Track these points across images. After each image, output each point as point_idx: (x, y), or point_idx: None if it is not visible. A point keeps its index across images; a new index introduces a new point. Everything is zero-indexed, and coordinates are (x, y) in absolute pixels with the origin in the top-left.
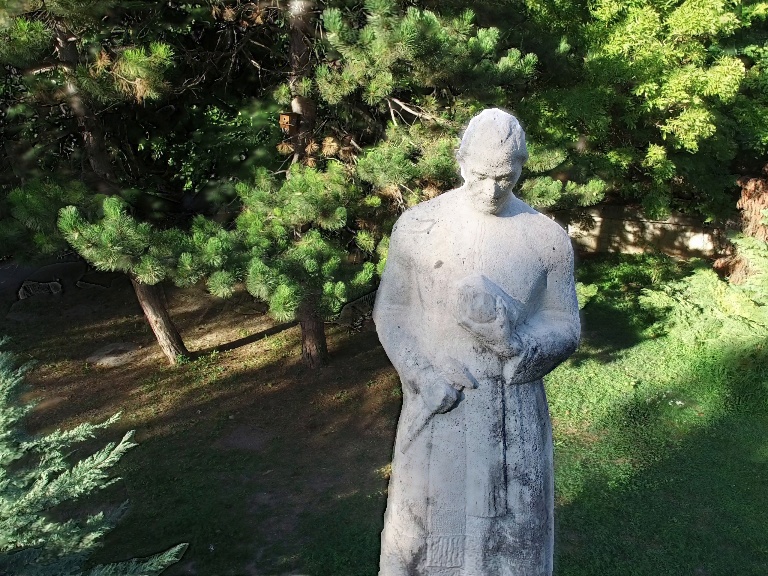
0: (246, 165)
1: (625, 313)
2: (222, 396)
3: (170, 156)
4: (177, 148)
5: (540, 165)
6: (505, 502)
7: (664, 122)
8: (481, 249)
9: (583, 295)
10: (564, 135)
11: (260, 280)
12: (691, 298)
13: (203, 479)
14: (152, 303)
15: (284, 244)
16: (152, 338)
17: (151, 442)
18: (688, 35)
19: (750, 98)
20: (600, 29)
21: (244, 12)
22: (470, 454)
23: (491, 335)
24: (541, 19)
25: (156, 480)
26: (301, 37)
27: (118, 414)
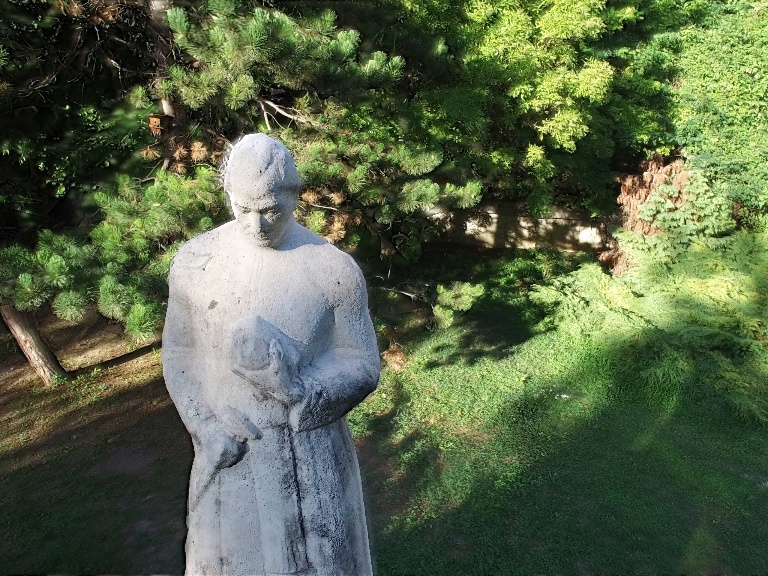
0: (110, 172)
1: (518, 308)
2: (101, 418)
3: (41, 160)
4: (48, 152)
5: (417, 168)
6: (304, 555)
7: (540, 123)
8: (256, 286)
9: (470, 295)
10: (446, 136)
11: (111, 300)
12: (578, 291)
13: (74, 512)
14: (19, 322)
15: (146, 258)
16: (22, 359)
17: (17, 475)
18: (559, 38)
19: (626, 98)
20: (477, 31)
21: (98, 8)
22: (260, 508)
23: (265, 382)
24: (421, 20)
25: (19, 518)
26: (156, 37)
27: None
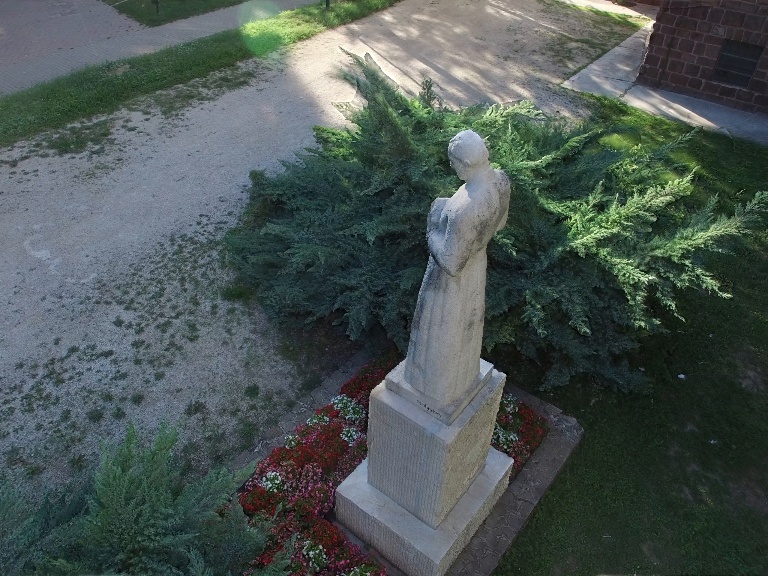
0: None
1: None
2: None
3: None
4: None
5: None
6: None
7: None
8: None
9: None
10: None
11: None
12: None
13: None
14: None
15: None
16: None
17: None
18: None
19: None
20: None
21: None
22: None
23: None
24: None
25: None
26: None
27: (730, 295)
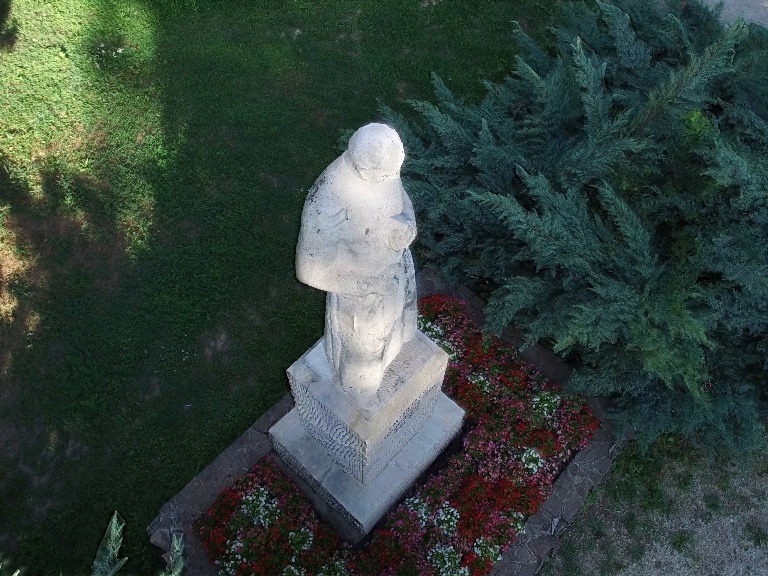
0: None
1: None
2: None
3: None
4: None
5: None
6: None
7: None
8: (381, 205)
9: None
10: None
11: None
12: None
13: None
14: None
15: None
16: None
17: None
18: None
19: None
20: None
21: None
22: None
23: None
24: None
25: None
26: None
27: None
